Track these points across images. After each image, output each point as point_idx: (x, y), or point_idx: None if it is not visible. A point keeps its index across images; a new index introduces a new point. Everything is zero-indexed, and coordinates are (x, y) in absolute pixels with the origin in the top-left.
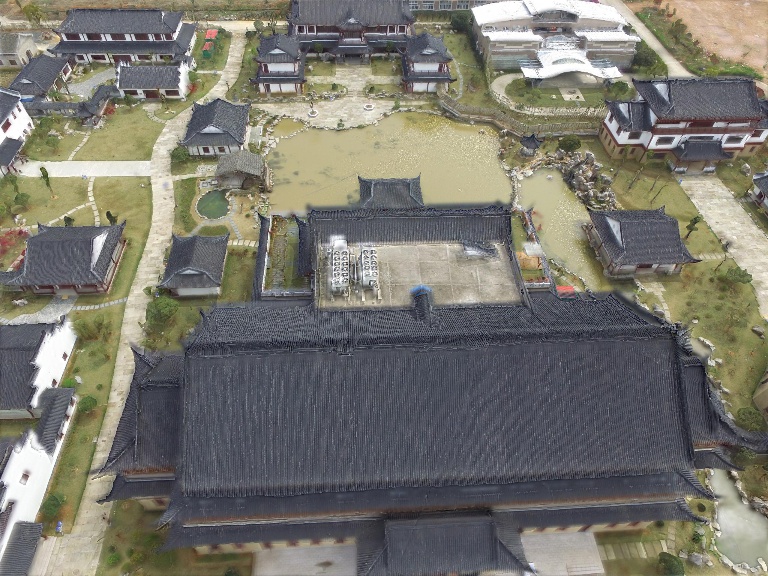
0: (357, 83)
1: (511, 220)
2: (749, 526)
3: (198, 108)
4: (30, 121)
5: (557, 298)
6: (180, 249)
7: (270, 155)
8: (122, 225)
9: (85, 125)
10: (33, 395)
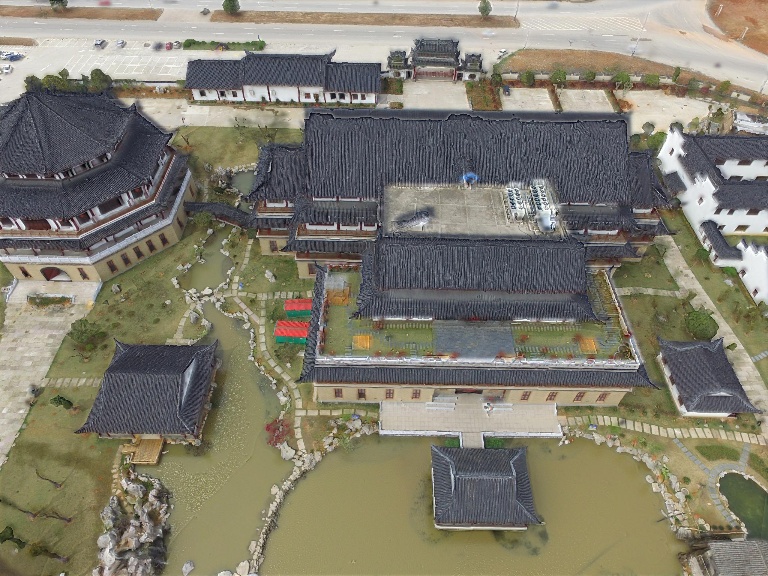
0: None
1: (336, 352)
2: (249, 186)
3: None
4: None
5: (321, 268)
6: None
7: None
8: None
9: None
10: (744, 245)
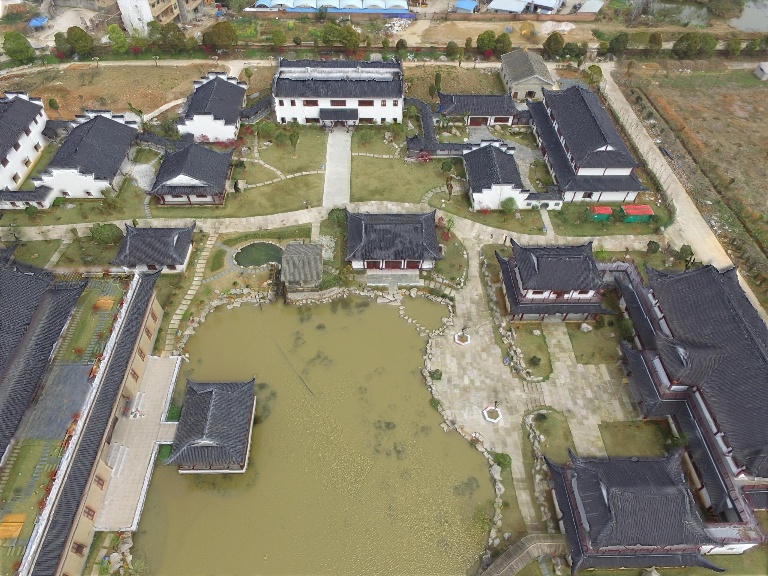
0: (564, 396)
1: (9, 569)
2: None
3: (424, 215)
4: (399, 118)
5: None
6: (168, 231)
7: (361, 298)
8: (220, 193)
9: (408, 151)
10: (39, 181)
